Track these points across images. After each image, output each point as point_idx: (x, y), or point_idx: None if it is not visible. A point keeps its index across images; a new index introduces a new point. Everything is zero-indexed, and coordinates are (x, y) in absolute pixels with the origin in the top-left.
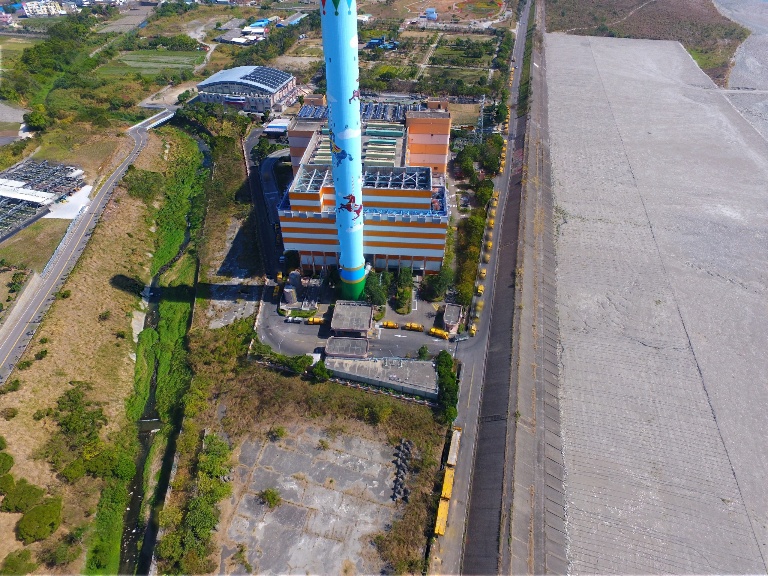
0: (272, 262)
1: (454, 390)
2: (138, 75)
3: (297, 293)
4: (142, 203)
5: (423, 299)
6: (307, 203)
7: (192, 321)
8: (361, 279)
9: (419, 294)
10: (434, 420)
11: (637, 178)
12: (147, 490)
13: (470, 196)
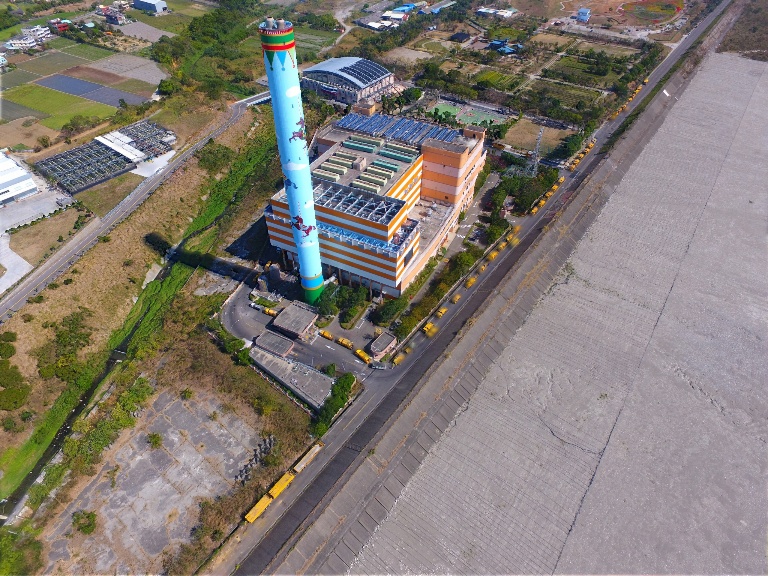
0: (271, 250)
1: (333, 410)
2: None
3: (271, 284)
4: (206, 173)
5: (371, 320)
6: (284, 211)
7: (185, 284)
8: (316, 288)
9: (369, 315)
10: (306, 429)
11: (690, 253)
12: (91, 402)
13: (485, 230)
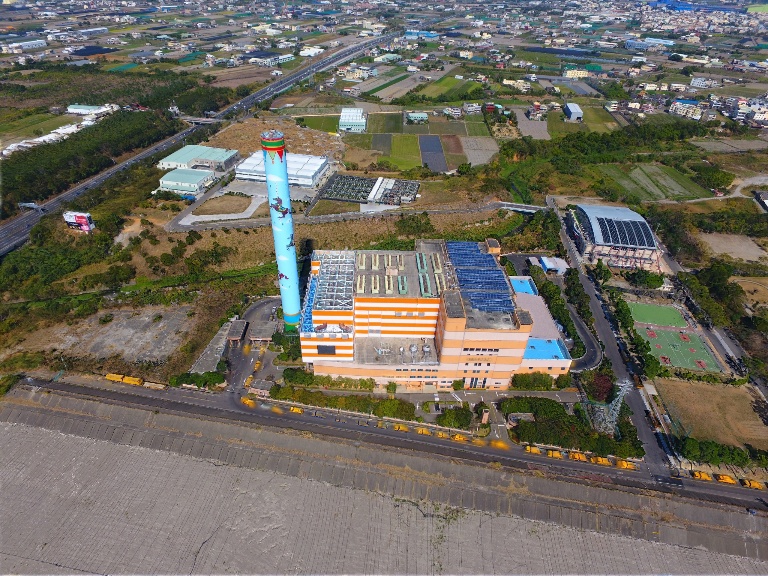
0: None
1: (186, 379)
2: (602, 180)
3: None
4: (395, 231)
5: None
6: None
7: None
8: (287, 323)
9: None
10: None
11: None
12: None
13: None
